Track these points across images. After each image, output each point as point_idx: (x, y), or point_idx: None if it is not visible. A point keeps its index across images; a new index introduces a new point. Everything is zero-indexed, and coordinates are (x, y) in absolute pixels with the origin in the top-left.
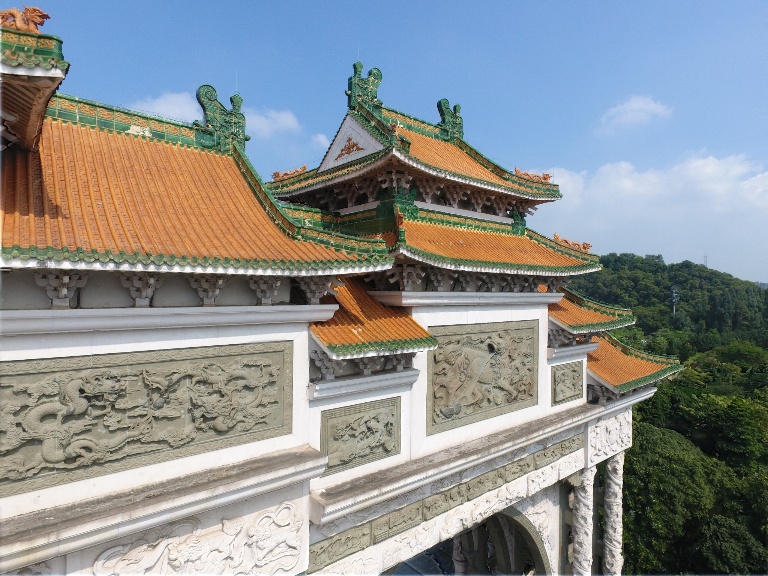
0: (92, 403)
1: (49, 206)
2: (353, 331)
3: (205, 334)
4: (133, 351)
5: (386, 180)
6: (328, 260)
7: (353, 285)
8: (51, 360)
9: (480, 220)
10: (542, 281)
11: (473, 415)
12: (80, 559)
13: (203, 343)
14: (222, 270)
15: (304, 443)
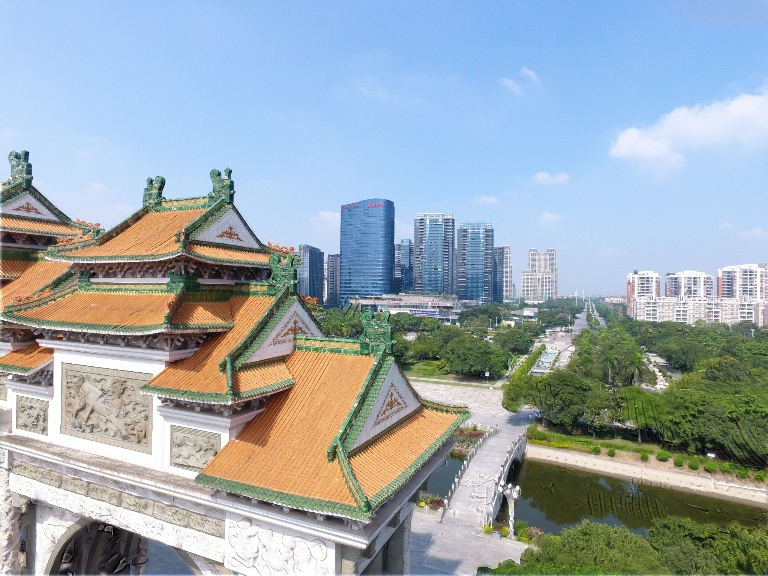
0: None
1: None
2: None
3: None
4: None
5: None
6: None
7: None
8: None
9: (136, 284)
10: (138, 338)
11: (92, 435)
12: None
13: None
14: None
15: None
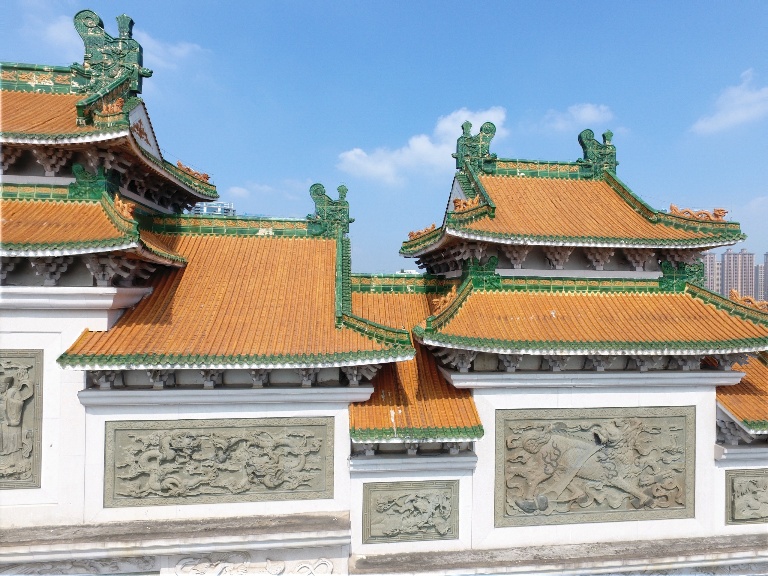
0: (178, 453)
1: (167, 314)
2: (391, 413)
3: (257, 408)
4: (205, 418)
5: (461, 252)
6: (349, 351)
7: (426, 358)
8: (155, 421)
9: (599, 280)
10: (692, 358)
11: (569, 515)
12: (168, 560)
13: (255, 415)
14: (247, 366)
15: (345, 509)
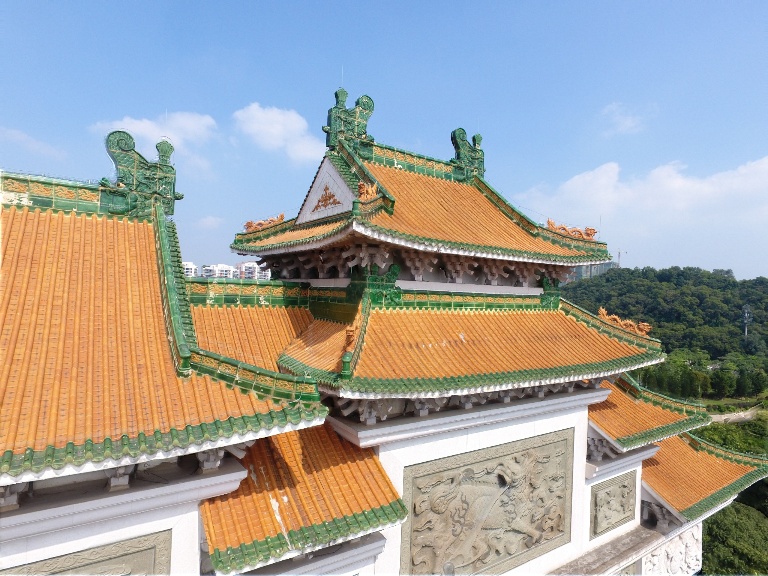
0: None
1: None
2: (273, 504)
3: (2, 550)
4: None
5: (355, 255)
6: (215, 421)
7: None
8: None
9: (495, 296)
10: None
11: None
12: None
13: None
14: None
15: None
